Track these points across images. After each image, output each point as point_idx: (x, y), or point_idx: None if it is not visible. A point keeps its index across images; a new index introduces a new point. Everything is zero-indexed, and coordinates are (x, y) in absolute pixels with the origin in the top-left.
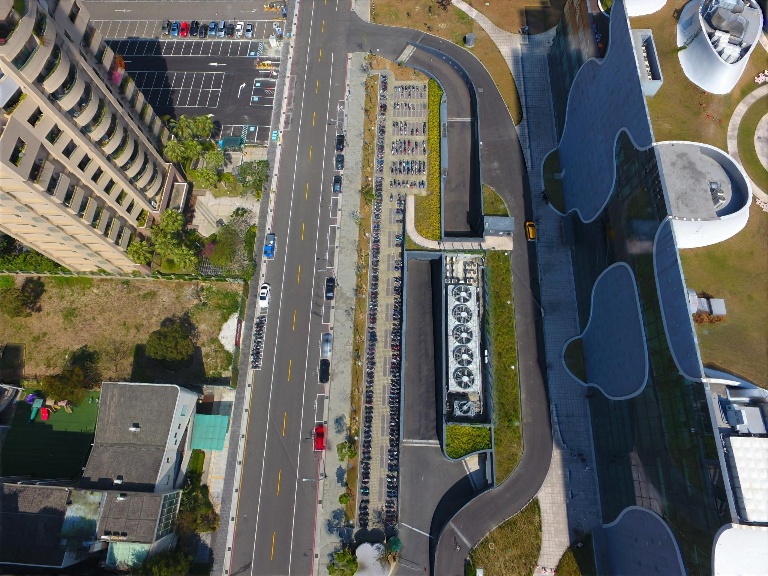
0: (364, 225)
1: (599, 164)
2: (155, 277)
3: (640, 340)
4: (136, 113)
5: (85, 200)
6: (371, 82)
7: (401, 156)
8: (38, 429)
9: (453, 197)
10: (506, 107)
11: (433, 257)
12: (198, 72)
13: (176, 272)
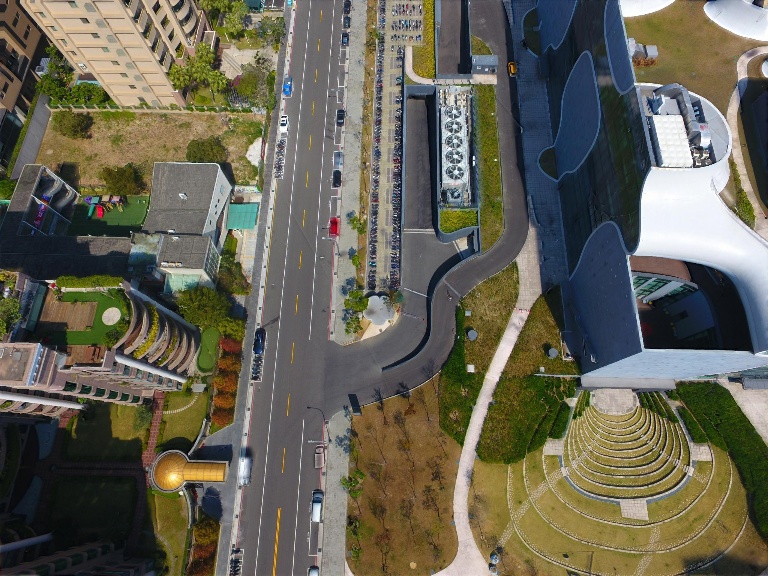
0: (369, 69)
1: None
2: (190, 108)
3: (595, 100)
4: None
5: (138, 11)
6: None
7: (400, 17)
8: (95, 224)
9: (446, 52)
10: None
11: (429, 92)
12: None
13: (208, 105)
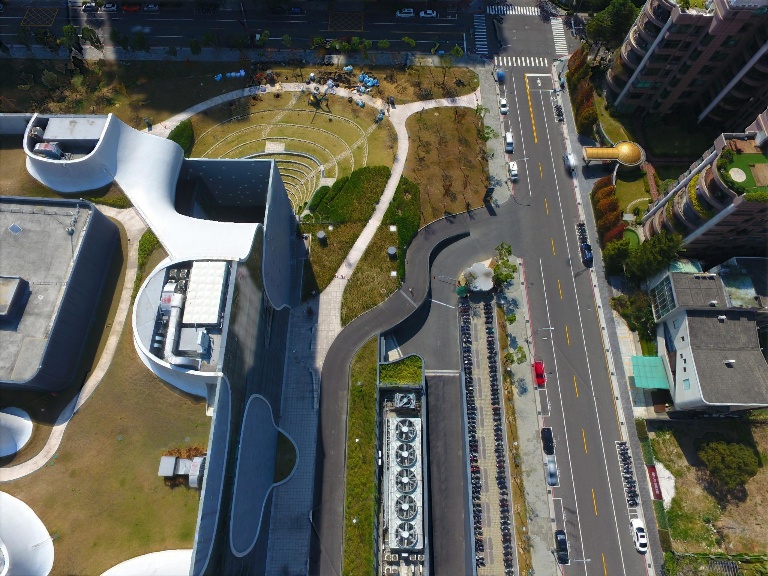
0: None
1: None
2: None
3: None
4: None
5: None
6: None
7: None
8: None
9: None
10: None
11: None
12: None
13: None
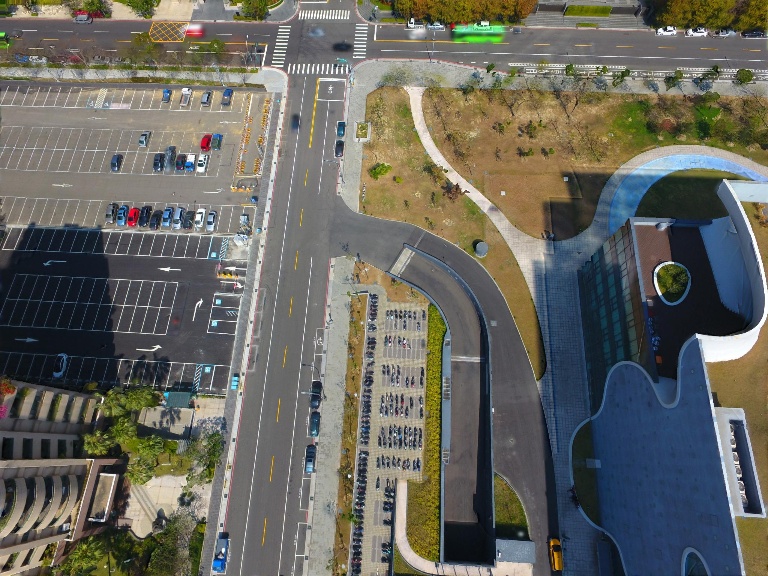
0: (342, 528)
1: (656, 542)
2: None
3: None
4: (40, 421)
5: None
6: (357, 305)
7: (392, 419)
8: None
9: (456, 472)
10: (525, 351)
11: None
12: (146, 281)
13: None
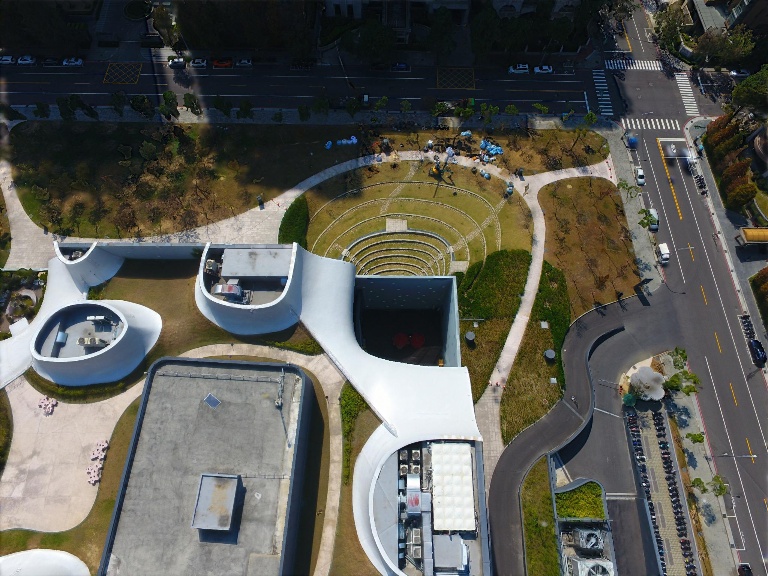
0: None
1: None
2: None
3: None
4: None
5: None
6: None
7: None
8: None
9: None
10: None
11: None
12: None
13: None
